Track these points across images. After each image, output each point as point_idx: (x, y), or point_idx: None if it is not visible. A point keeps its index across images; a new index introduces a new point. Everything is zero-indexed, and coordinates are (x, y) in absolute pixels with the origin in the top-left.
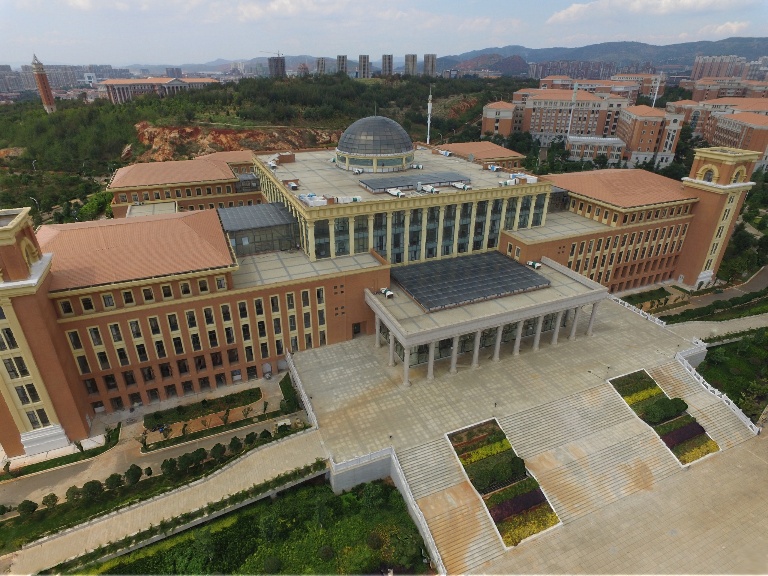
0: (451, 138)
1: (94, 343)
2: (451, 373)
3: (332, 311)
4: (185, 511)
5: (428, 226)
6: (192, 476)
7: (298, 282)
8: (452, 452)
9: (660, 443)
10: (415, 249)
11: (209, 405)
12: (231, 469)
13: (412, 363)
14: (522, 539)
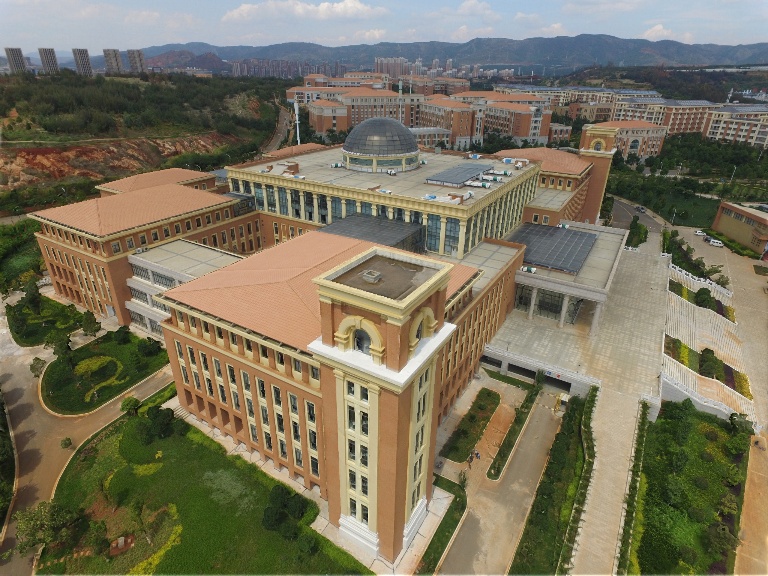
0: None
1: None
2: (600, 317)
3: (503, 297)
4: (622, 486)
5: None
6: (562, 470)
7: (499, 275)
8: (676, 363)
9: (719, 316)
10: (496, 232)
11: None
12: (598, 443)
13: (570, 320)
14: None
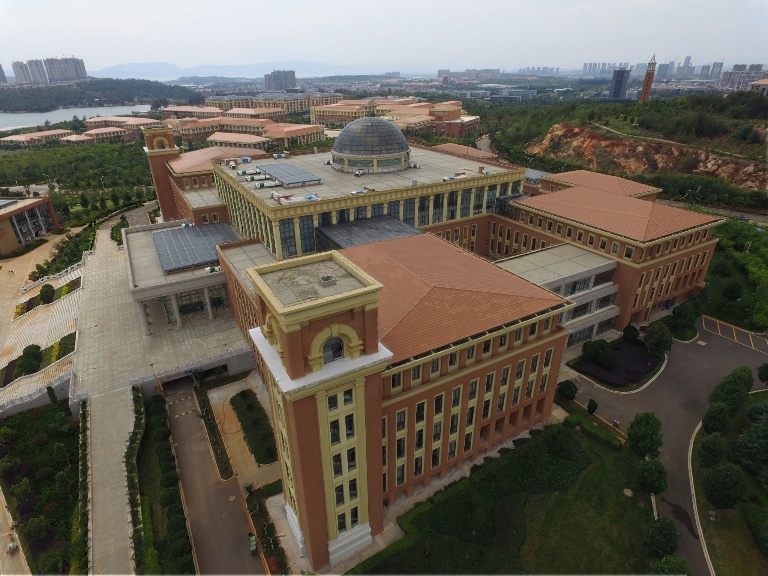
0: None
1: None
2: None
3: None
4: None
5: None
6: None
7: None
8: None
9: None
10: None
11: None
12: None
13: None
14: None
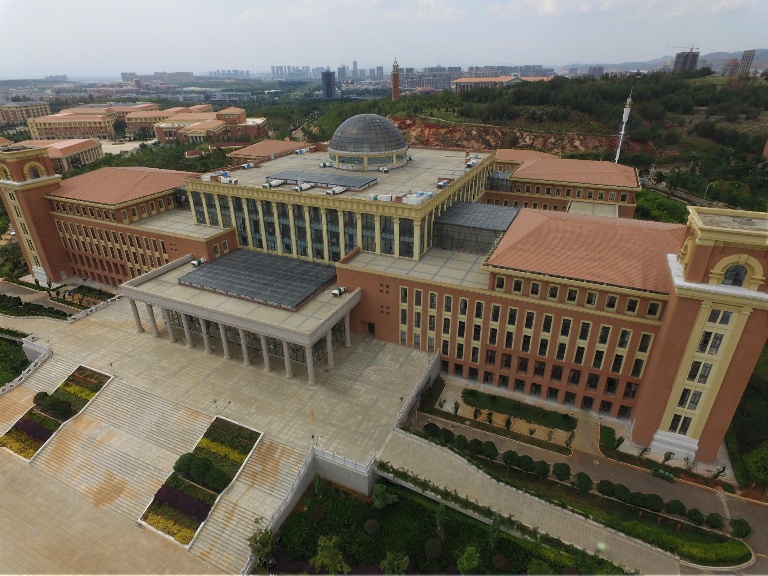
0: (691, 159)
1: (67, 231)
2: (169, 341)
3: None
4: None
5: (281, 221)
6: None
7: (147, 230)
8: None
9: None
10: (273, 240)
11: (101, 294)
12: (26, 319)
13: (172, 323)
14: (6, 447)
